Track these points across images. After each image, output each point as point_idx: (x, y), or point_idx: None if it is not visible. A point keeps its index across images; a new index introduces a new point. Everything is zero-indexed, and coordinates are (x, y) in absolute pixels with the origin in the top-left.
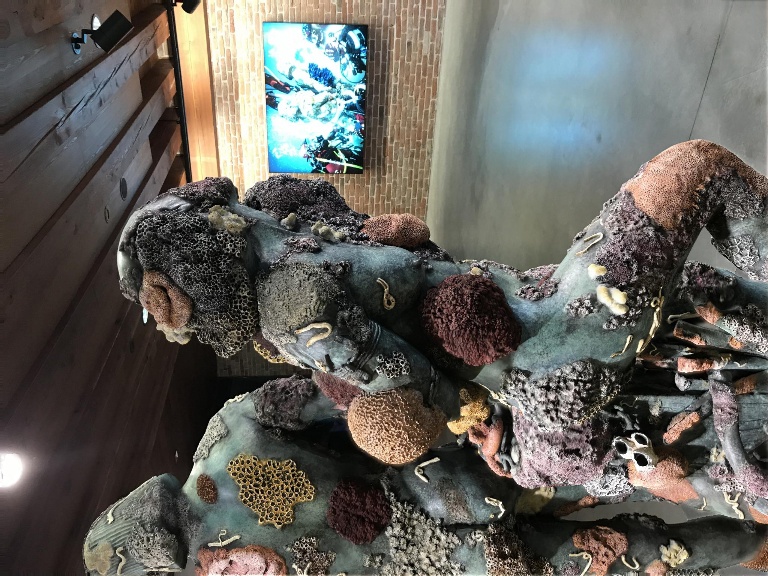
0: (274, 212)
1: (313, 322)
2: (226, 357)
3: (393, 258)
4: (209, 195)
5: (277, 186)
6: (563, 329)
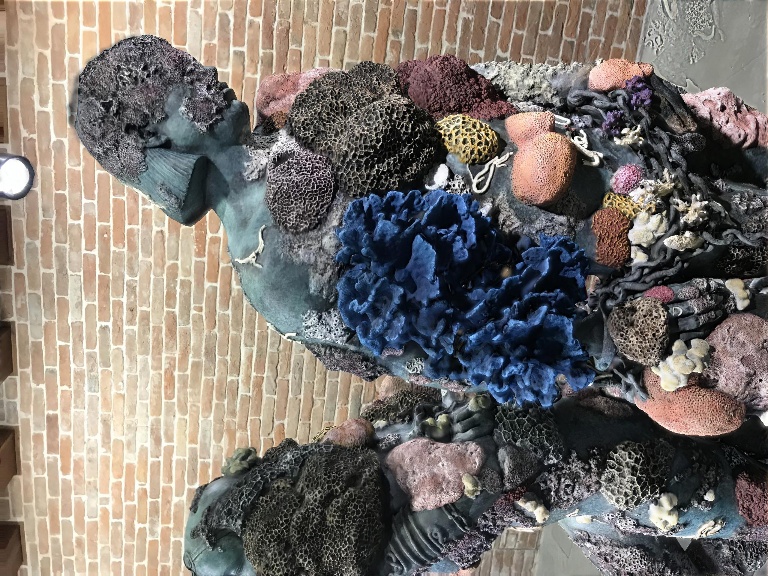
0: None
1: None
2: (290, 439)
3: None
4: None
5: None
6: None
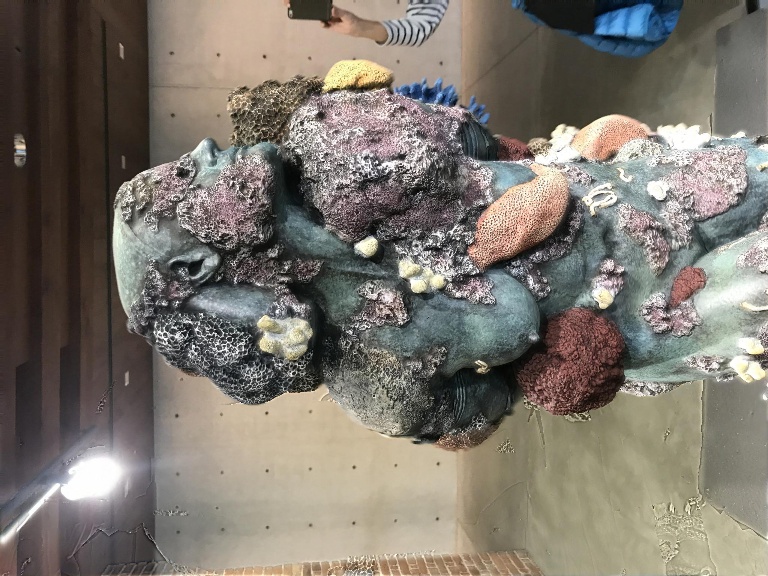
0: (345, 234)
1: (392, 435)
2: None
3: (504, 336)
4: (246, 242)
5: (352, 194)
6: (670, 371)
